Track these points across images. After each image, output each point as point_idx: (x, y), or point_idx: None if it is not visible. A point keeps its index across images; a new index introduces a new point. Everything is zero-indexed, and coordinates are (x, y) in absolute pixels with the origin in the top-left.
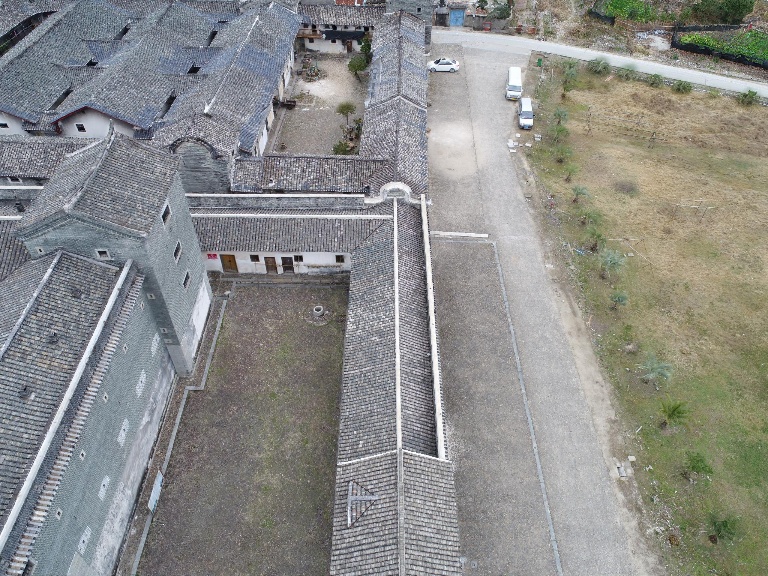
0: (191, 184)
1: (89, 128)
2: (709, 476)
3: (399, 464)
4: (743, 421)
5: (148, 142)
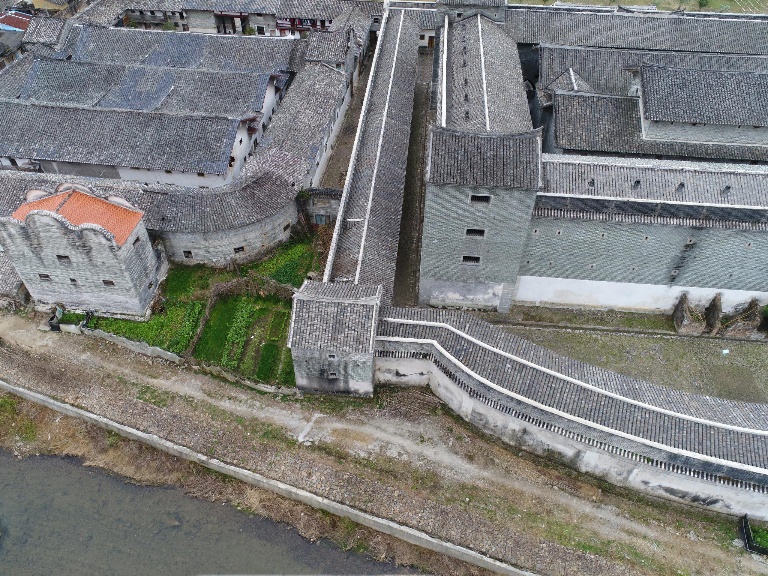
0: None
1: (263, 103)
2: None
3: (562, 2)
4: None
5: (303, 73)
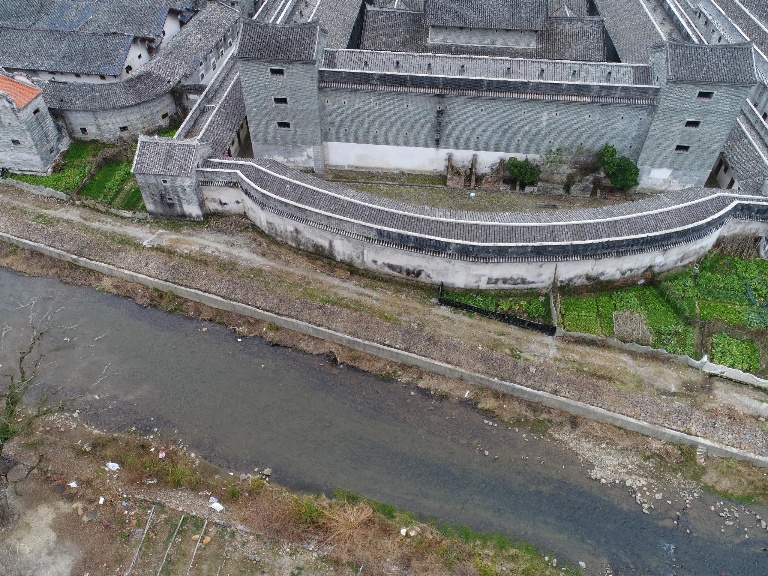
0: (247, 8)
1: (166, 31)
2: None
3: None
4: None
5: None
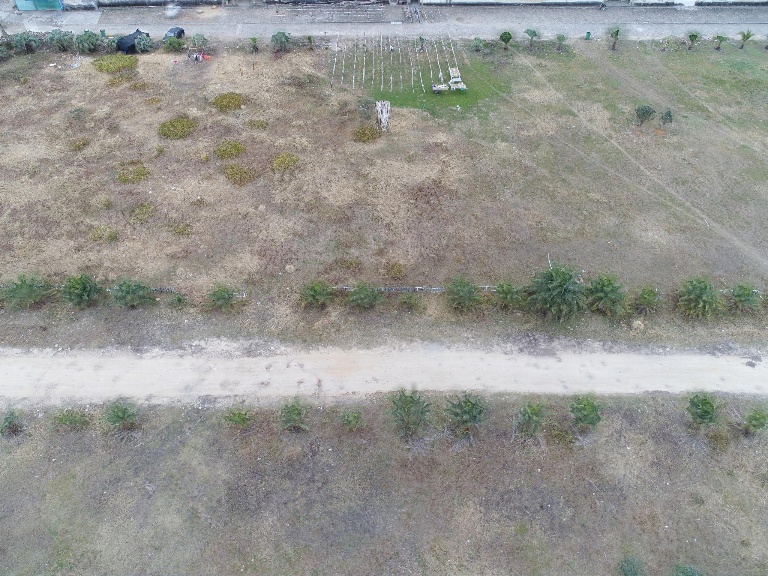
0: None
1: None
2: (722, 54)
3: None
4: (764, 66)
5: None
